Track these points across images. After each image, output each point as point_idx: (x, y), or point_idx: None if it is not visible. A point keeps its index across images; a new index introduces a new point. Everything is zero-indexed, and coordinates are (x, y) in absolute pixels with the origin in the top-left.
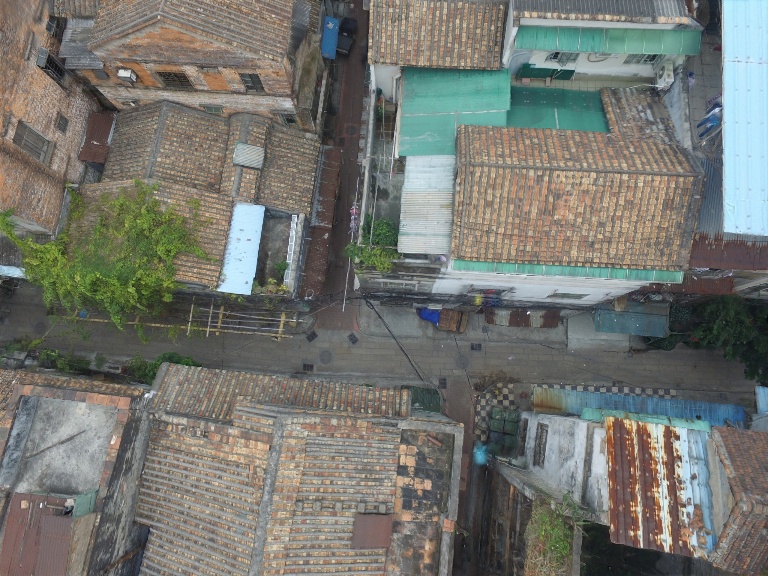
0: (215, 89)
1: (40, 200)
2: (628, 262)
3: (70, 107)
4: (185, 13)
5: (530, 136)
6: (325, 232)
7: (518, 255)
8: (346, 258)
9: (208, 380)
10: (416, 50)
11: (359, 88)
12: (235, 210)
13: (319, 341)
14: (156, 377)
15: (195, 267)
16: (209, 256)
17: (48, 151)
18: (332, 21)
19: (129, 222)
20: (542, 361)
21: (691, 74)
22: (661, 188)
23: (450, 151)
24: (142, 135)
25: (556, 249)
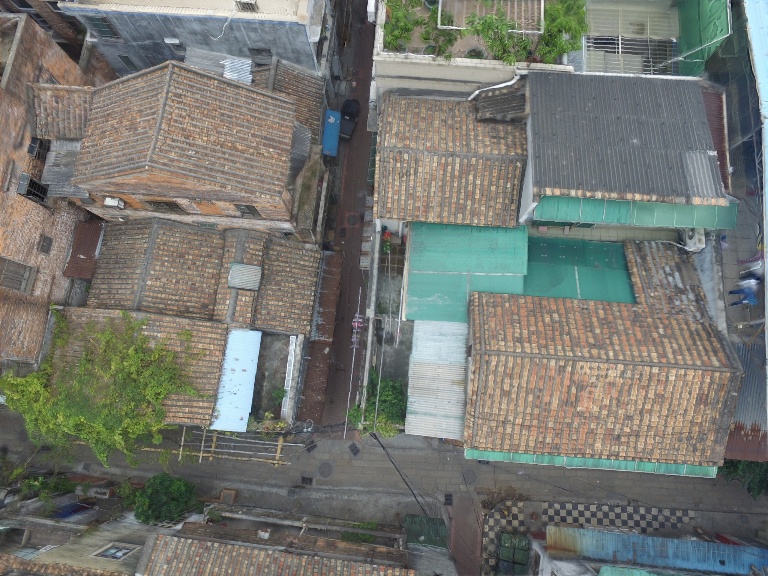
0: (209, 213)
1: (21, 332)
2: (657, 456)
3: (55, 224)
4: (175, 159)
5: (550, 310)
6: (325, 346)
7: (537, 447)
8: (347, 360)
9: (199, 557)
10: (425, 206)
11: (361, 174)
12: (230, 337)
13: (318, 452)
14: (142, 554)
15: (186, 406)
16: (202, 392)
17: (30, 278)
18: (333, 115)
19: (115, 364)
20: (553, 477)
21: (724, 237)
22: (695, 382)
23: (462, 318)
24: (131, 254)
25: (579, 441)
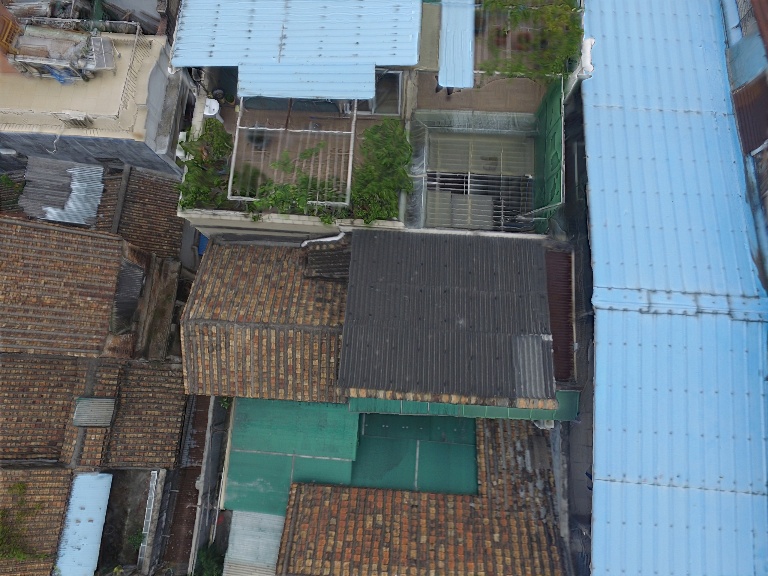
0: None
1: None
2: None
3: None
4: None
5: (374, 511)
6: (199, 472)
7: None
8: None
9: None
10: (241, 382)
11: None
12: (75, 483)
13: None
14: None
15: (18, 571)
16: (38, 553)
17: None
18: None
19: None
20: None
21: None
22: None
23: (283, 511)
24: None
25: None
